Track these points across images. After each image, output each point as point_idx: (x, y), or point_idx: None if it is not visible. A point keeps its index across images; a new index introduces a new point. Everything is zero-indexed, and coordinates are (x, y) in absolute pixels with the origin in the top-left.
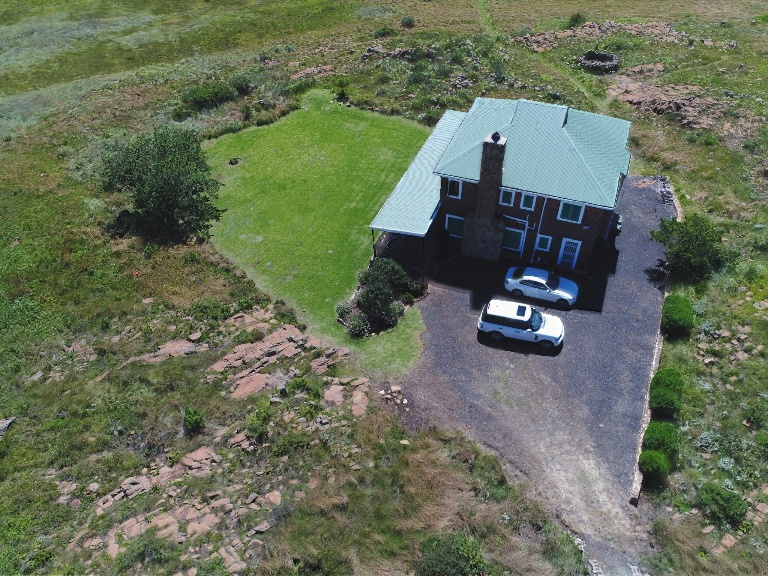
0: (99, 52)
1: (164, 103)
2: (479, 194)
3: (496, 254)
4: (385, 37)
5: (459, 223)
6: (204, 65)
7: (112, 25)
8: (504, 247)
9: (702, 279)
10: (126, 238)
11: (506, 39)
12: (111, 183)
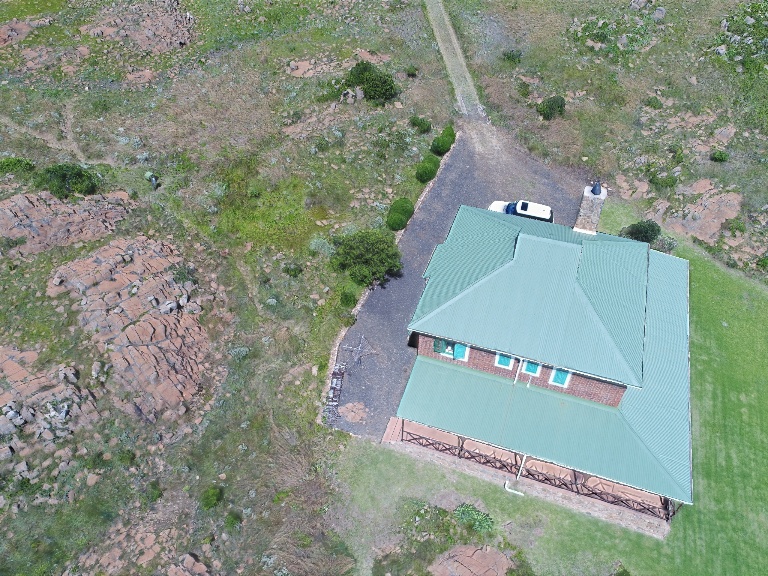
0: None
1: None
2: None
3: None
4: None
5: None
6: None
7: None
8: None
9: None
10: None
11: None
12: None
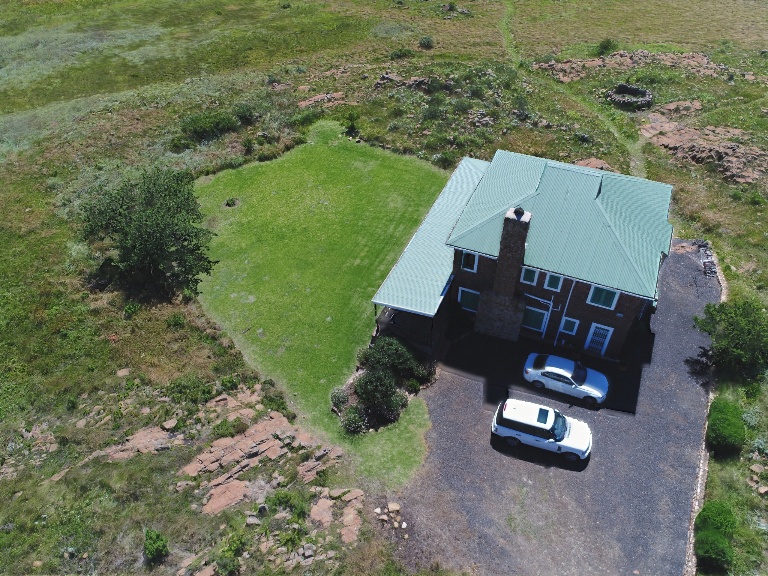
0: (103, 68)
1: (163, 130)
2: (497, 271)
3: (514, 334)
4: (401, 59)
5: (474, 297)
6: (209, 86)
7: (119, 38)
8: (524, 326)
9: (754, 381)
10: (107, 291)
11: (530, 65)
12: (92, 231)
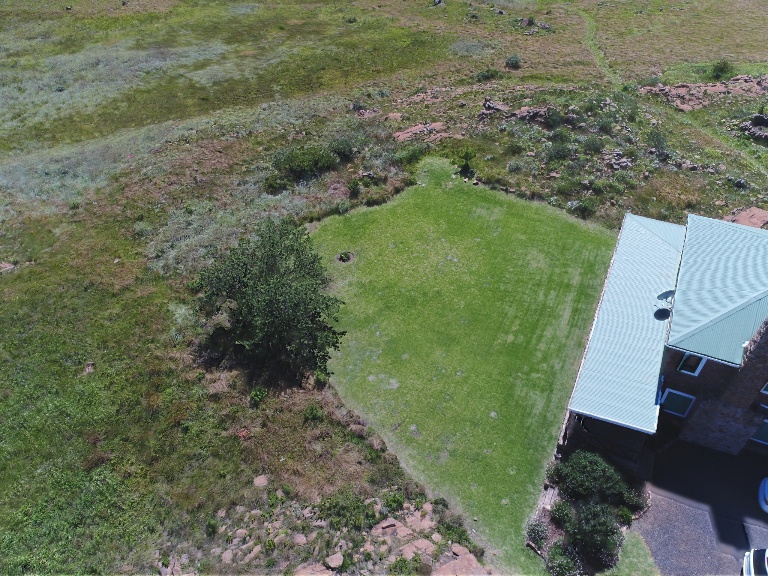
0: (170, 90)
1: (252, 167)
2: (735, 380)
3: (736, 447)
4: (489, 80)
5: (684, 400)
6: (290, 113)
7: (182, 56)
8: None
9: None
10: (223, 369)
11: (635, 89)
12: (209, 301)
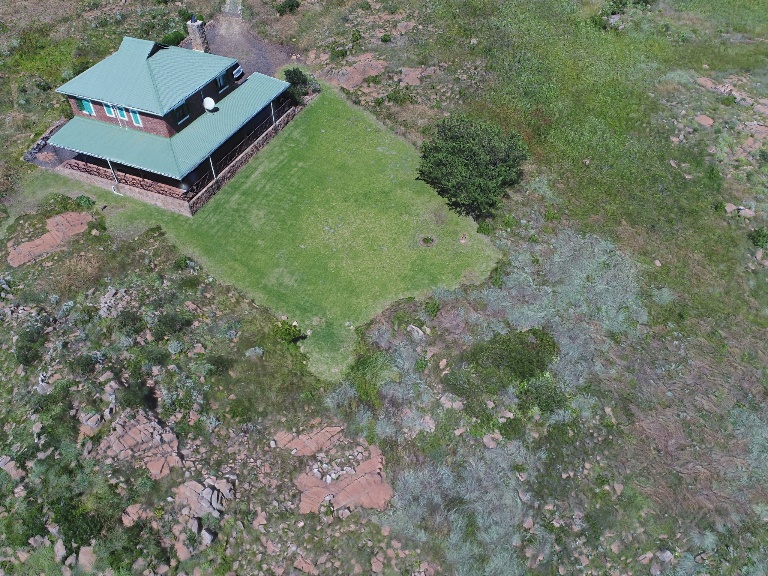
0: None
1: None
2: None
3: None
4: None
5: None
6: None
7: None
8: None
9: None
10: None
11: None
12: None
